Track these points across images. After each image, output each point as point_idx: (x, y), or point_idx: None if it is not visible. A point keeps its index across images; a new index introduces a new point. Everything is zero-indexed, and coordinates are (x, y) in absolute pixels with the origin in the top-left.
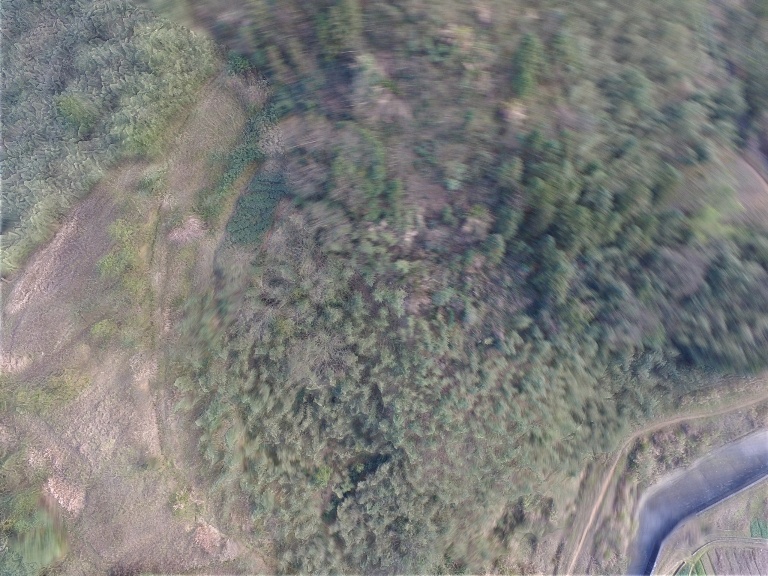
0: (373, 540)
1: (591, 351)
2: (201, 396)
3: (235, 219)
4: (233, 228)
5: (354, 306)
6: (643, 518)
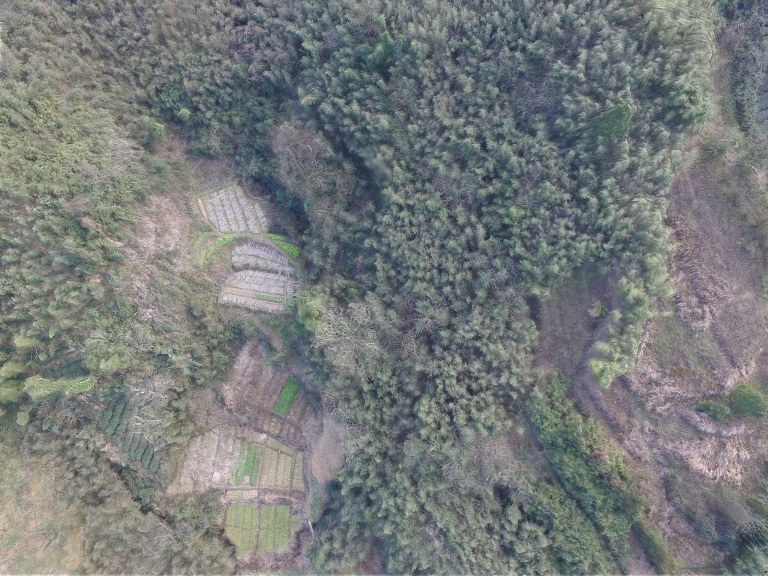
0: None
1: None
2: None
3: (763, 156)
4: (766, 164)
5: None
6: None
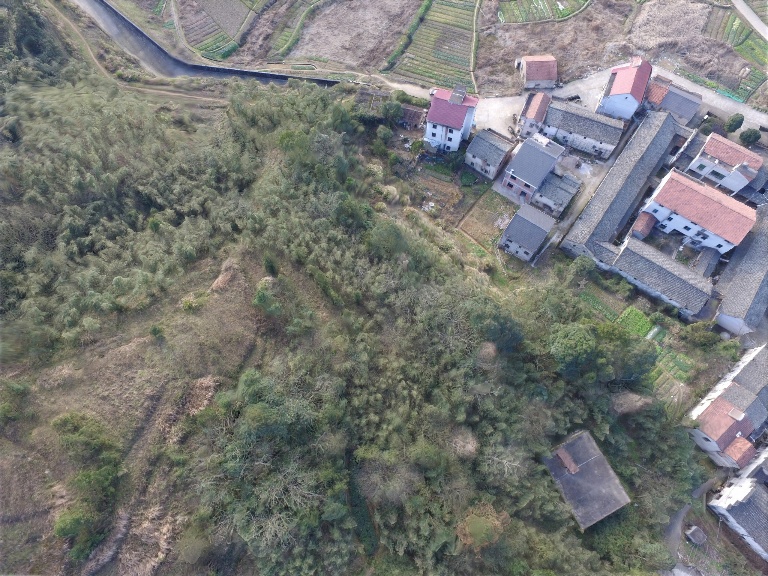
0: None
1: None
2: None
3: None
4: None
5: None
6: None
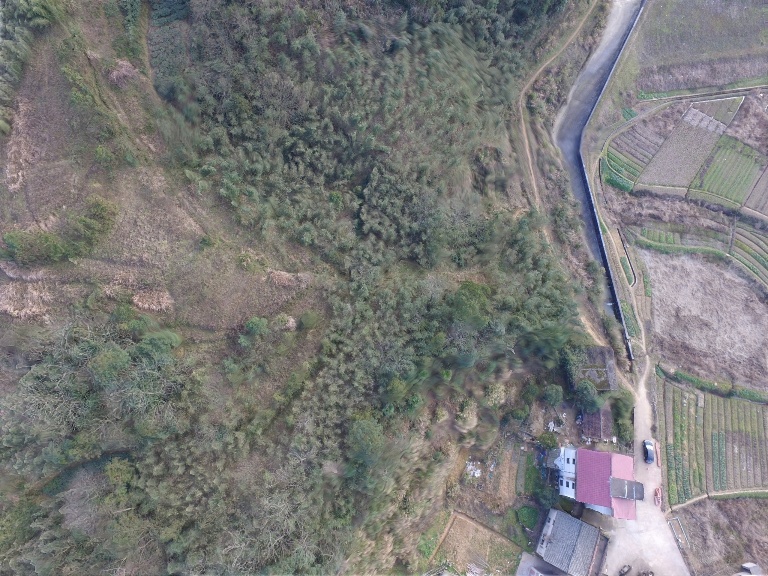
0: (398, 224)
1: (457, 25)
2: (212, 180)
3: (153, 55)
4: (156, 62)
5: (283, 65)
6: (561, 148)
